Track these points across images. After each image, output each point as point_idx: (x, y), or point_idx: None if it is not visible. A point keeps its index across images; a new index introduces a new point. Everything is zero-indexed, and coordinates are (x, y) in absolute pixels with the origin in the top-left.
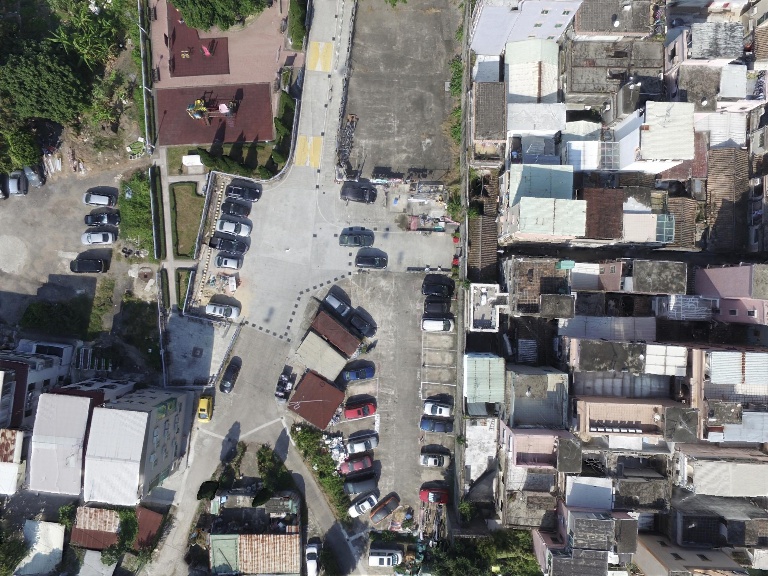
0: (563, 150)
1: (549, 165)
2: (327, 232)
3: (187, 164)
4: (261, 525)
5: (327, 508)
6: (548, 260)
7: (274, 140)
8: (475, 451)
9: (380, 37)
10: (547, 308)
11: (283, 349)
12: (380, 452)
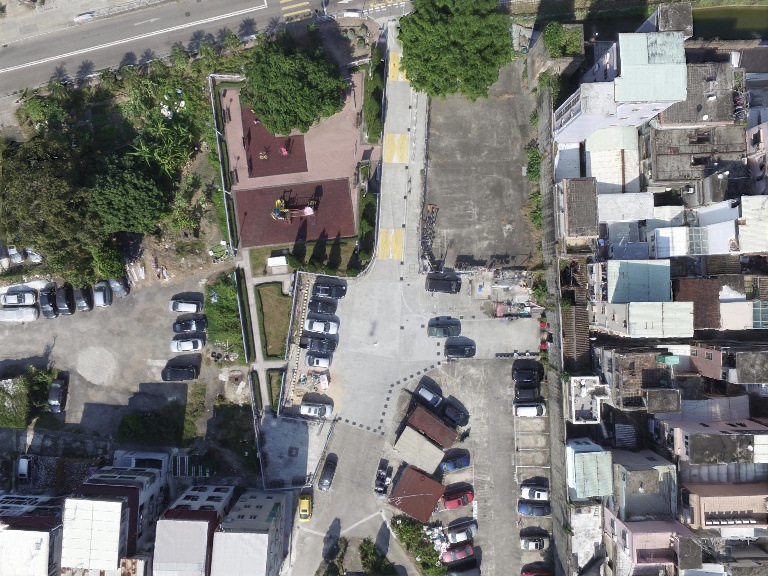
0: (648, 234)
1: (646, 260)
2: (414, 323)
3: (272, 266)
4: None
5: None
6: (650, 354)
7: (356, 235)
8: (581, 538)
9: (455, 126)
10: (654, 404)
11: (378, 443)
12: (479, 538)
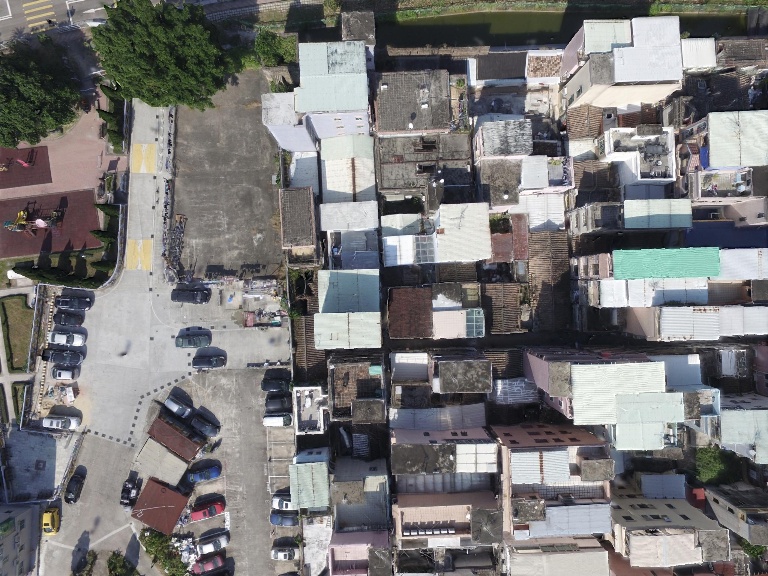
0: None
1: (355, 270)
2: (164, 334)
3: (14, 278)
4: None
5: None
6: (360, 364)
7: (102, 246)
8: (314, 549)
9: (203, 135)
10: (358, 414)
11: (127, 455)
12: (232, 549)
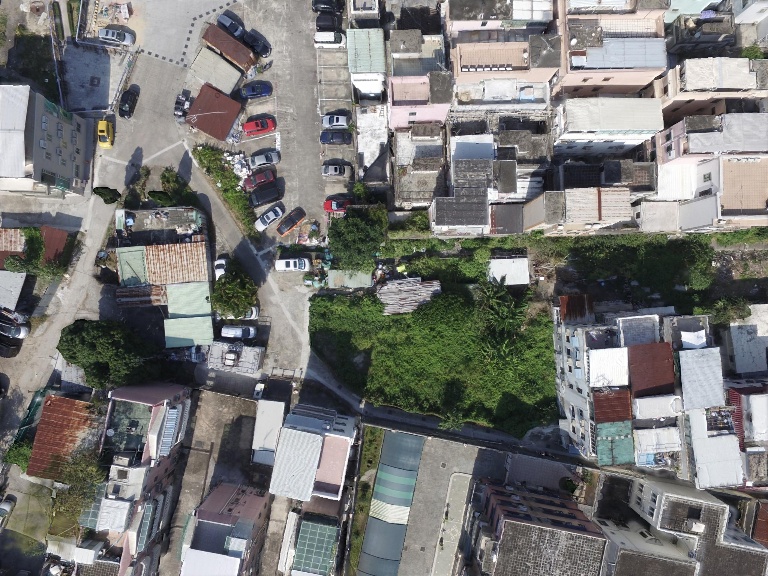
0: None
1: None
2: None
3: None
4: None
5: (234, 225)
6: None
7: None
8: (367, 138)
9: None
10: None
11: (180, 74)
12: (283, 169)
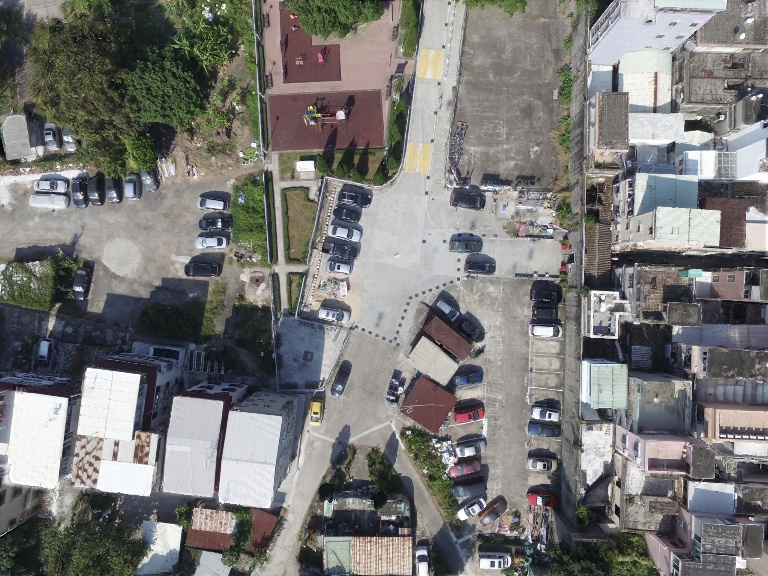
0: (676, 159)
1: (674, 175)
2: (436, 238)
3: (300, 170)
4: (370, 527)
5: (436, 511)
6: (673, 268)
7: (385, 146)
8: (591, 456)
9: (490, 45)
10: (674, 316)
11: (392, 353)
12: (488, 456)
